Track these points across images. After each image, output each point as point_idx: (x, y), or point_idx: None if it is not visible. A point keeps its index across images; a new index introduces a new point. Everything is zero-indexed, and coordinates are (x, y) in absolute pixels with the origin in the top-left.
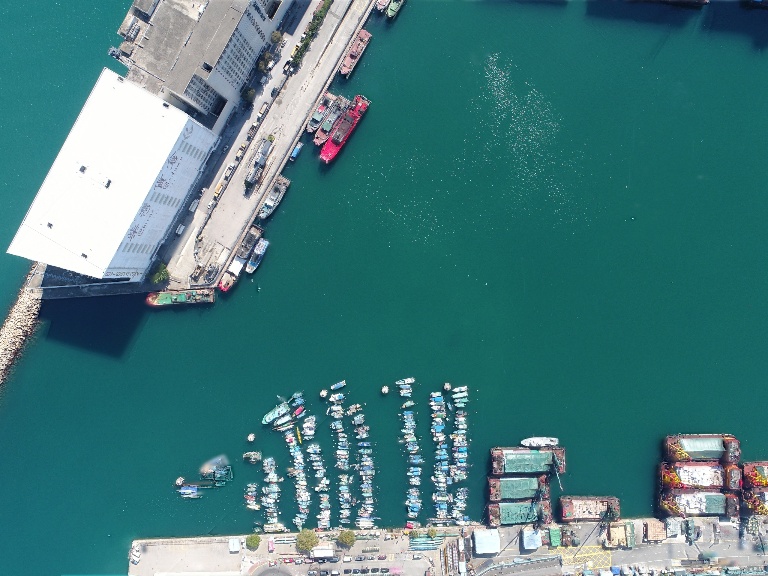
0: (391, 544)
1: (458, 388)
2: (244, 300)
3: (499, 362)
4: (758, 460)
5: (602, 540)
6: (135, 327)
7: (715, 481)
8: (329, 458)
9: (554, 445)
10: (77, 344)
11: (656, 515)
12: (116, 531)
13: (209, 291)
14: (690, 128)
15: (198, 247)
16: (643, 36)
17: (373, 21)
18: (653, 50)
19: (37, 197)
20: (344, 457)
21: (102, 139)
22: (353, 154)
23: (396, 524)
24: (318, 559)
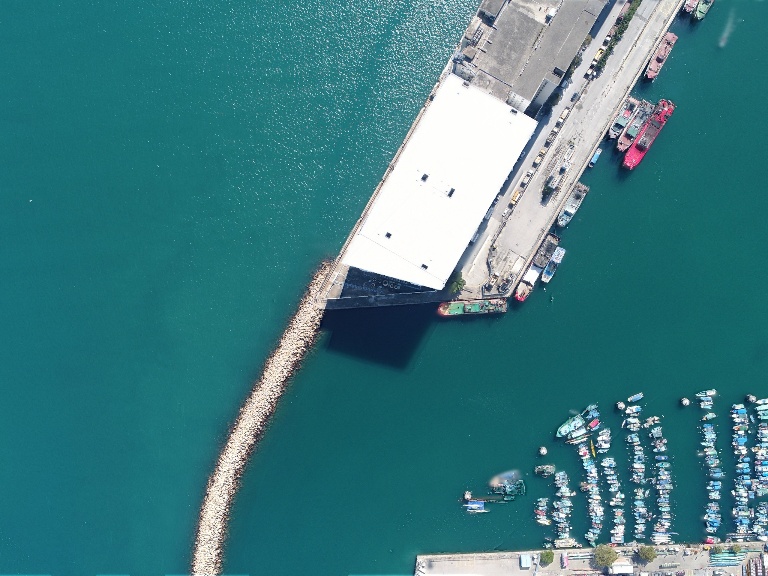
0: (690, 560)
1: (762, 400)
2: (537, 310)
3: None
4: None
5: None
6: (421, 338)
7: None
8: (624, 472)
9: None
10: (359, 355)
11: None
12: (397, 546)
13: (503, 301)
14: None
15: (491, 256)
16: None
17: (678, 23)
18: None
19: (374, 206)
20: (641, 471)
21: (446, 146)
22: (655, 160)
23: (693, 539)
24: (613, 575)
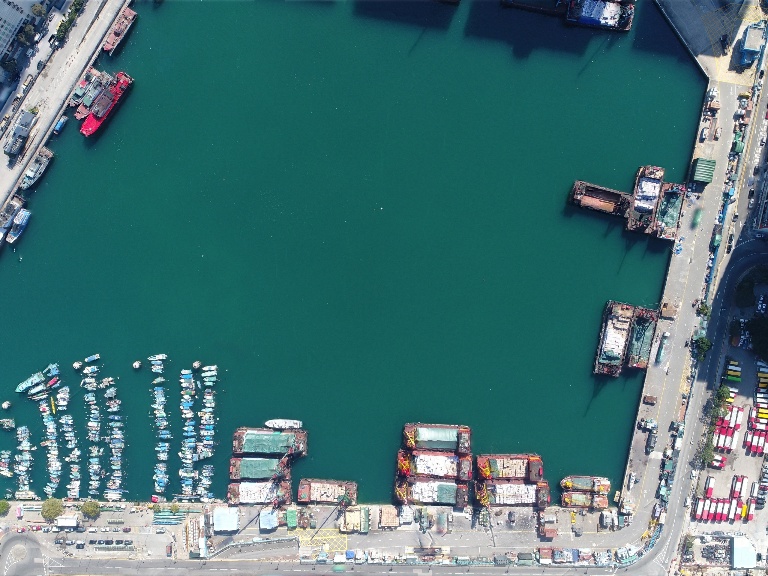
0: (136, 517)
1: (208, 367)
2: (5, 269)
3: (248, 343)
4: (493, 453)
5: (339, 524)
6: None
7: (450, 471)
8: (81, 429)
9: (297, 428)
10: None
11: (393, 502)
12: None
13: None
14: (442, 122)
15: None
16: (400, 29)
17: None
18: (410, 43)
19: None
20: (94, 429)
21: None
22: (115, 130)
23: (144, 498)
24: (65, 528)
